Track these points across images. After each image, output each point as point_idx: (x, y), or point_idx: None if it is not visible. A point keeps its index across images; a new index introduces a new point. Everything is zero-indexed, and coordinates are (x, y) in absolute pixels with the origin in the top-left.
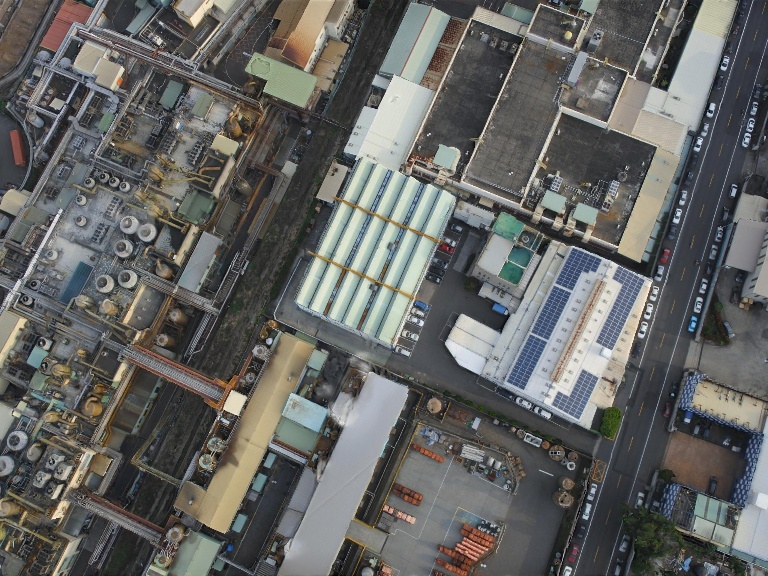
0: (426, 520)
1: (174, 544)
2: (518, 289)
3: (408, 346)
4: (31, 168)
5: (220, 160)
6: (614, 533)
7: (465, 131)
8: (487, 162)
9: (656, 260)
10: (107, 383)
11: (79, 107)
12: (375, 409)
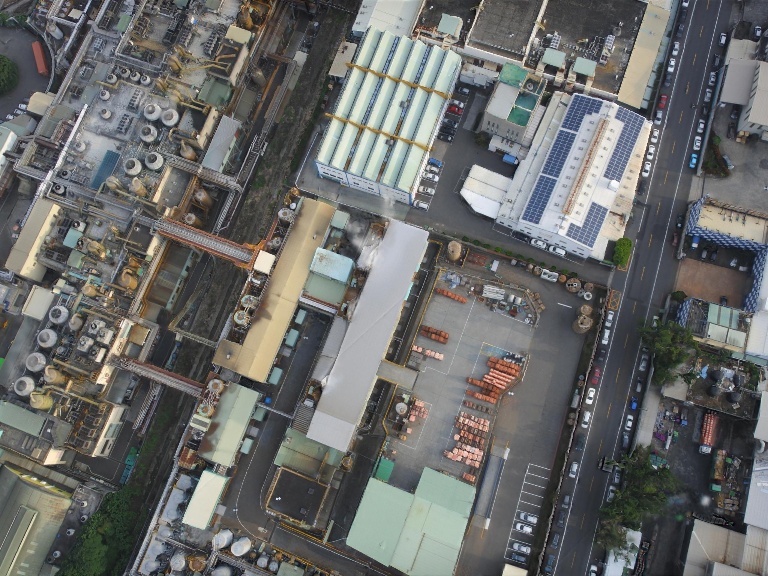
0: (453, 357)
1: (215, 394)
2: (526, 138)
3: (425, 201)
4: (54, 75)
5: (235, 48)
6: (633, 355)
7: (465, 2)
8: (488, 27)
9: (654, 105)
10: (141, 257)
11: (97, 12)
12: (399, 252)
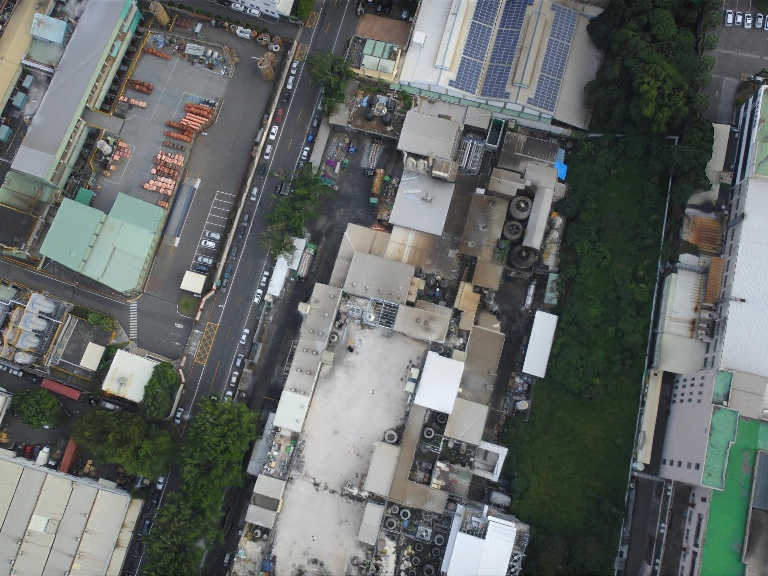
0: (157, 105)
1: None
2: None
3: None
4: None
5: None
6: (314, 97)
7: None
8: None
9: None
10: None
11: None
12: (102, 10)
